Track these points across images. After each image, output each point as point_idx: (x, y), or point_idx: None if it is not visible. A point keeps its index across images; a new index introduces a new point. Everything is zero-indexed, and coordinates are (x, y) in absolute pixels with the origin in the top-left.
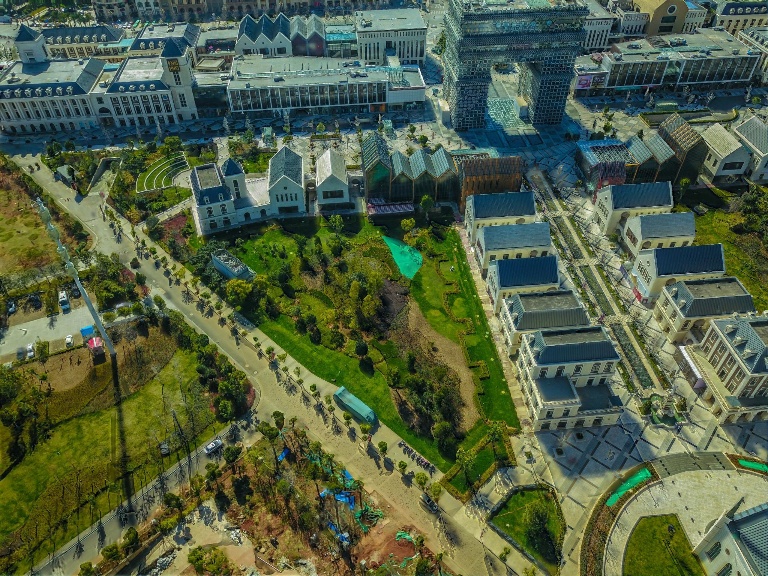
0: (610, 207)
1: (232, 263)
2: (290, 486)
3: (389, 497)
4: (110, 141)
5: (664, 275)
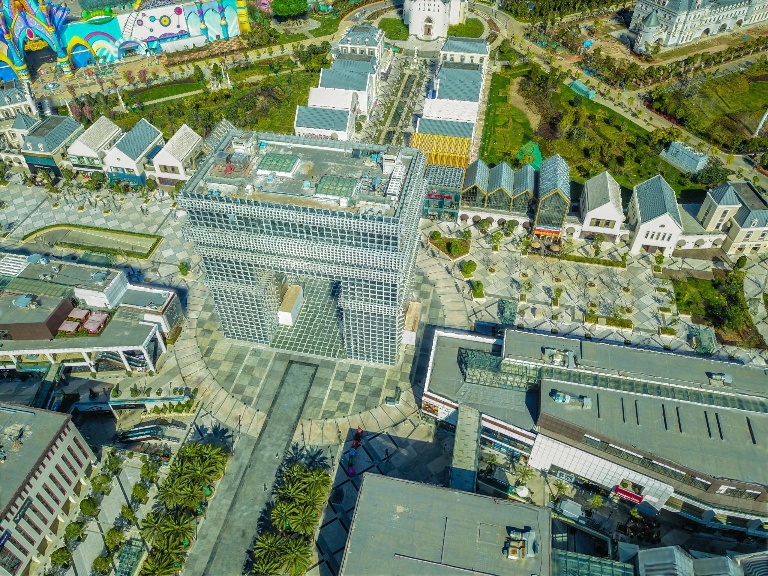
0: None
1: (687, 150)
2: (617, 69)
3: (567, 67)
4: None
5: None
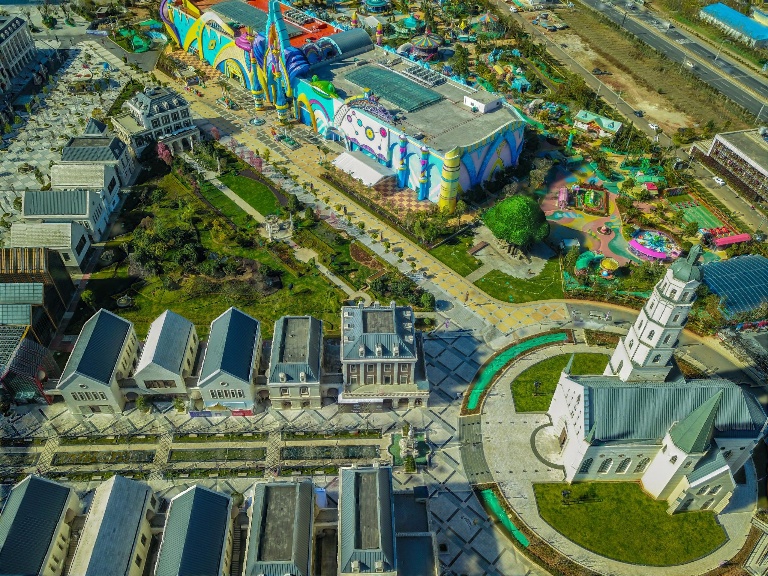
0: (101, 388)
1: None
2: None
3: None
4: None
5: (249, 376)
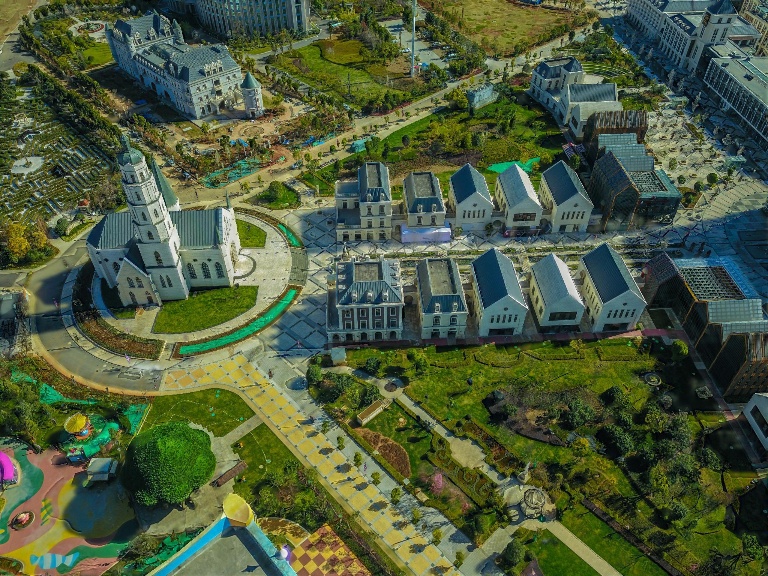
0: None
1: None
2: None
3: None
4: (631, 46)
5: (473, 266)
